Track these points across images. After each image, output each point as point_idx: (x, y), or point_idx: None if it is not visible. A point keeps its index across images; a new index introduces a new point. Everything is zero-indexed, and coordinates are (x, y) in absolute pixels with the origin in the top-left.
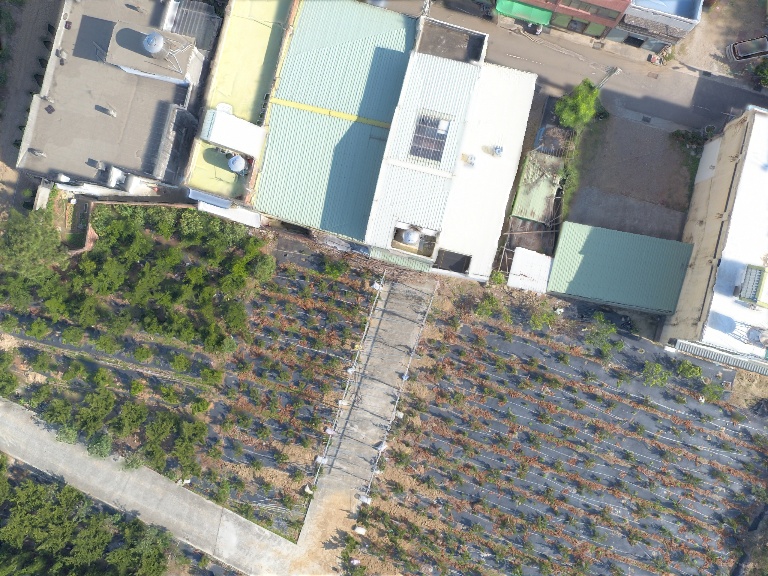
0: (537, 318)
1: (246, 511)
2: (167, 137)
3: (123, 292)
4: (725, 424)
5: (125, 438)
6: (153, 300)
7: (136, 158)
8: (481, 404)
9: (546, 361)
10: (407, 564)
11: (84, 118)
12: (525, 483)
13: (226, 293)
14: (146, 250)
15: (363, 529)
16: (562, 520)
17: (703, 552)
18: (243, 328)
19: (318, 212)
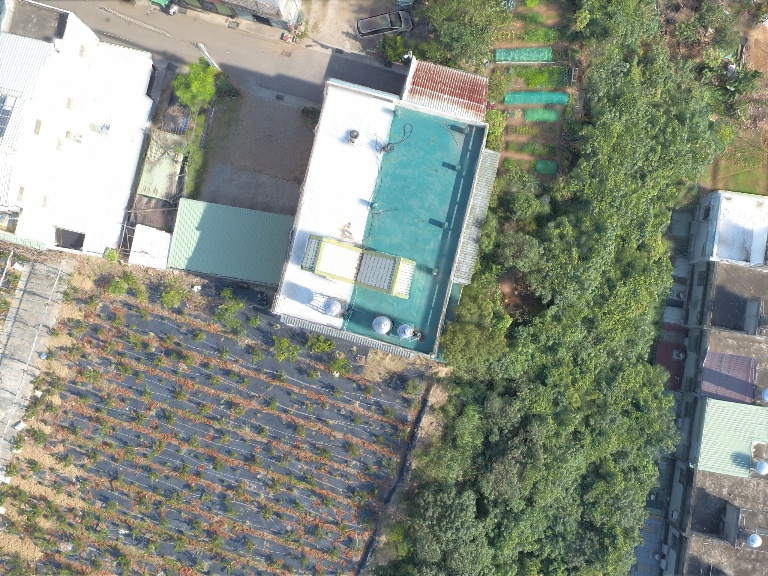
0: None
1: None
2: None
3: None
4: (358, 398)
5: None
6: None
7: None
8: (119, 382)
9: (183, 338)
10: None
11: None
12: (162, 460)
13: None
14: None
15: (3, 508)
16: (198, 496)
17: (337, 525)
18: None
19: None
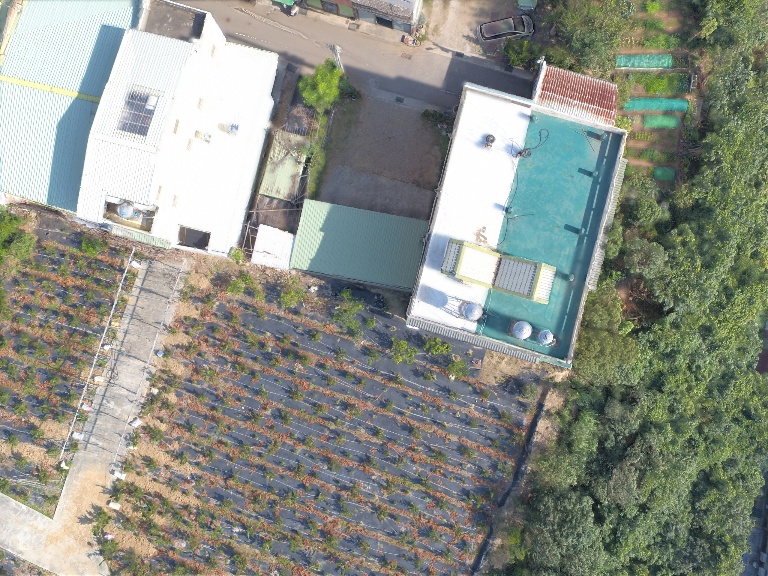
0: (286, 295)
1: (3, 486)
2: None
3: None
4: (474, 401)
5: None
6: None
7: None
8: (235, 381)
9: (299, 338)
10: (158, 539)
11: None
12: (277, 459)
13: None
14: None
15: (118, 504)
16: (312, 496)
17: (451, 528)
18: (2, 305)
19: (44, 188)
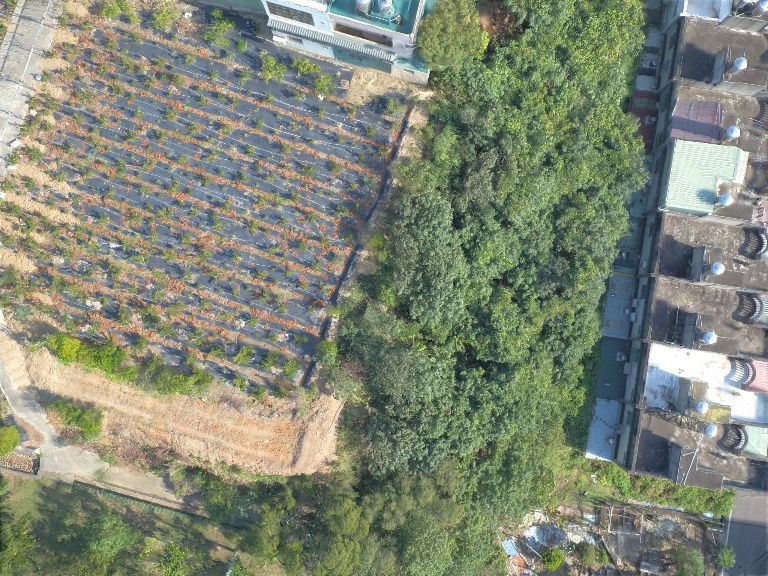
0: (159, 16)
1: None
2: None
3: None
4: (342, 119)
5: None
6: None
7: None
8: (111, 103)
9: (173, 62)
10: None
11: None
12: (153, 177)
13: None
14: None
15: None
16: (186, 211)
17: (319, 240)
18: None
19: None
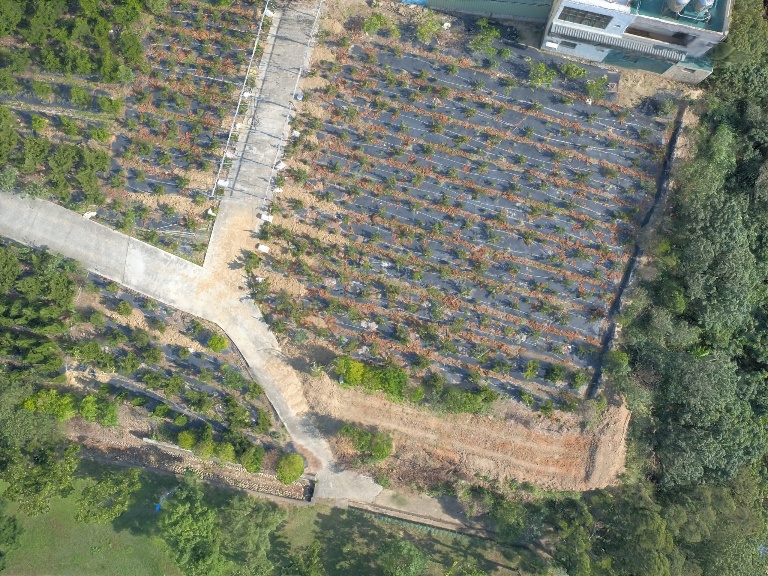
0: None
1: (152, 237)
2: None
3: (22, 36)
4: (612, 123)
5: (31, 177)
6: (52, 42)
7: None
8: (375, 119)
9: (436, 74)
10: None
11: None
12: (422, 193)
13: (122, 30)
14: None
15: (266, 247)
16: (459, 225)
17: (597, 248)
18: (140, 61)
19: None
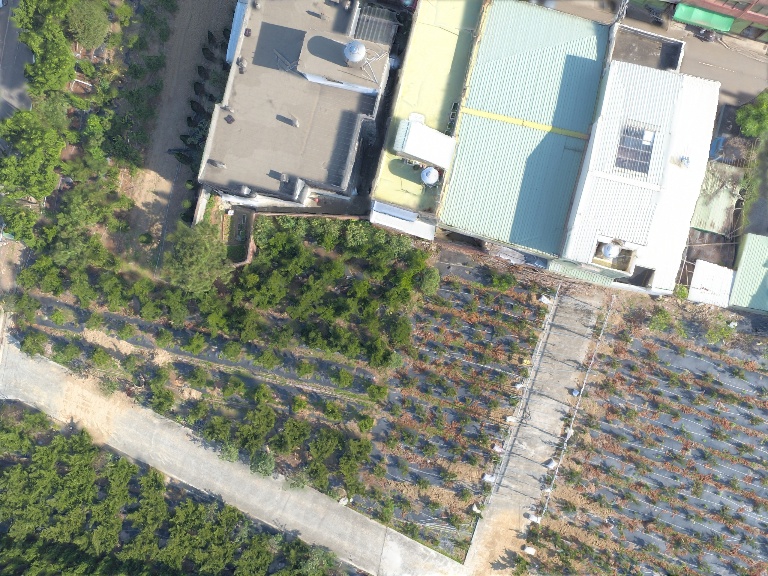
0: (714, 332)
1: (411, 531)
2: (354, 148)
3: (281, 306)
4: None
5: (284, 456)
6: (312, 314)
7: (320, 169)
8: (653, 420)
9: (720, 376)
10: None
11: (265, 128)
12: (699, 501)
13: (388, 307)
14: (310, 263)
15: (533, 549)
16: (738, 539)
17: None
18: (407, 343)
19: (507, 225)
